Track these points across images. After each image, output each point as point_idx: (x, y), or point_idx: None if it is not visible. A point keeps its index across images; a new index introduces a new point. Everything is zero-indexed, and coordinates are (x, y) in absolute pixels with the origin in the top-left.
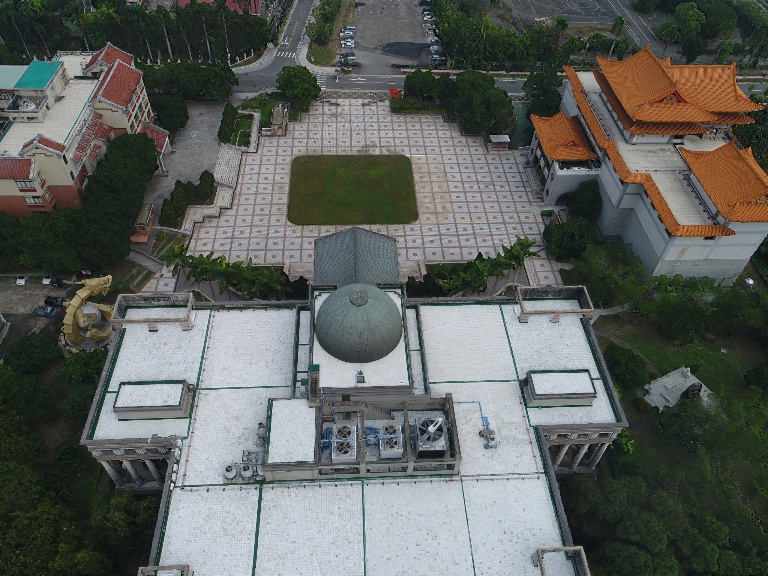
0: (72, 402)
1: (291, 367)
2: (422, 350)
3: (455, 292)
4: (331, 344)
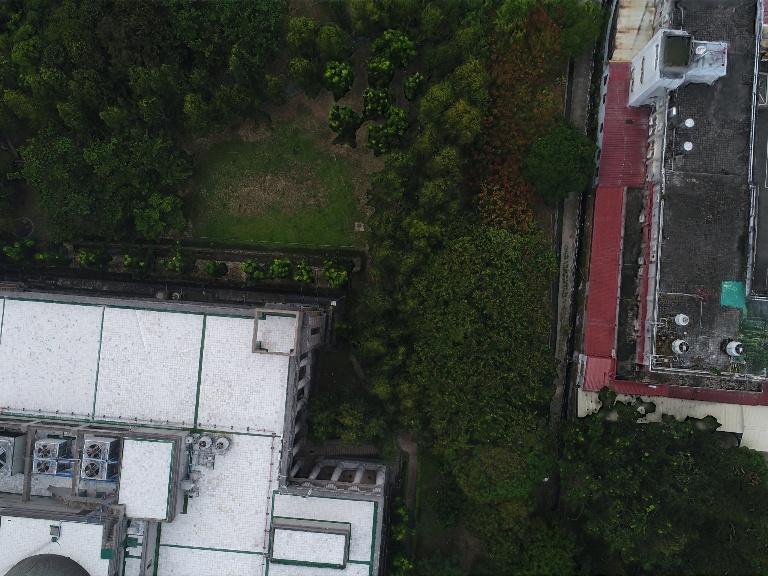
0: (444, 574)
1: (160, 572)
2: None
3: None
4: None
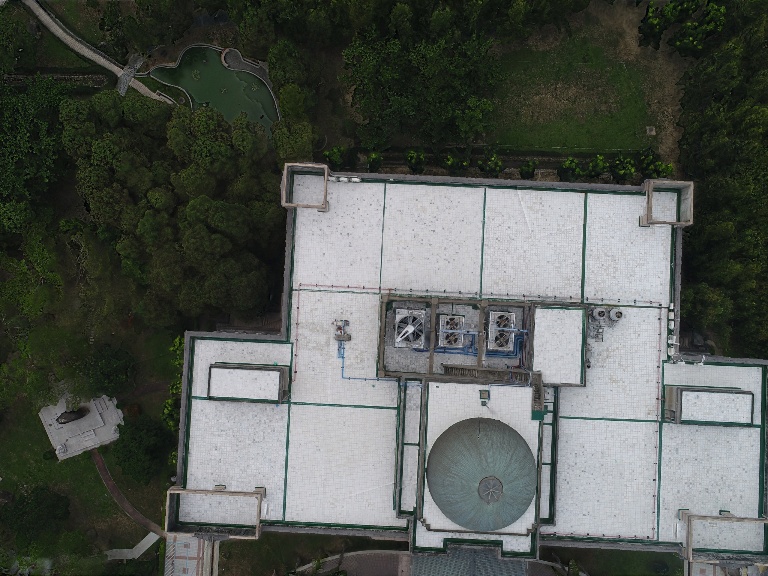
0: None
1: None
2: (402, 443)
3: (328, 573)
4: (521, 439)
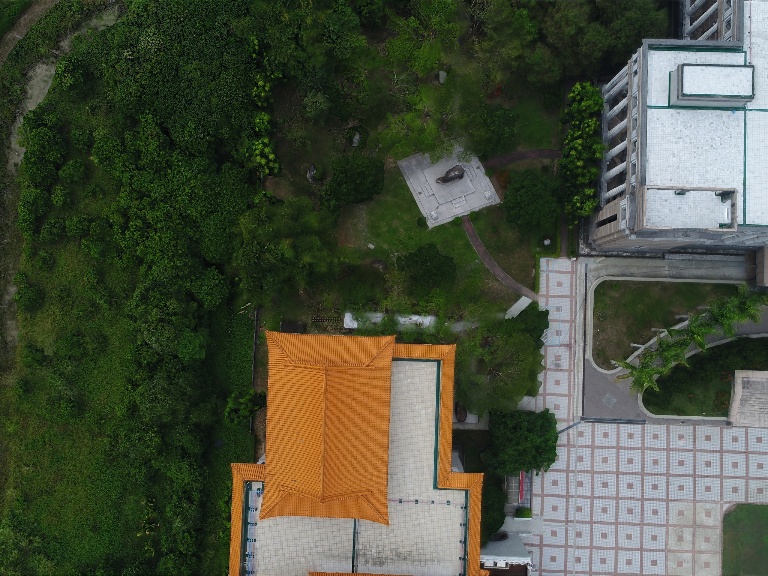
0: None
1: None
2: None
3: None
4: None
